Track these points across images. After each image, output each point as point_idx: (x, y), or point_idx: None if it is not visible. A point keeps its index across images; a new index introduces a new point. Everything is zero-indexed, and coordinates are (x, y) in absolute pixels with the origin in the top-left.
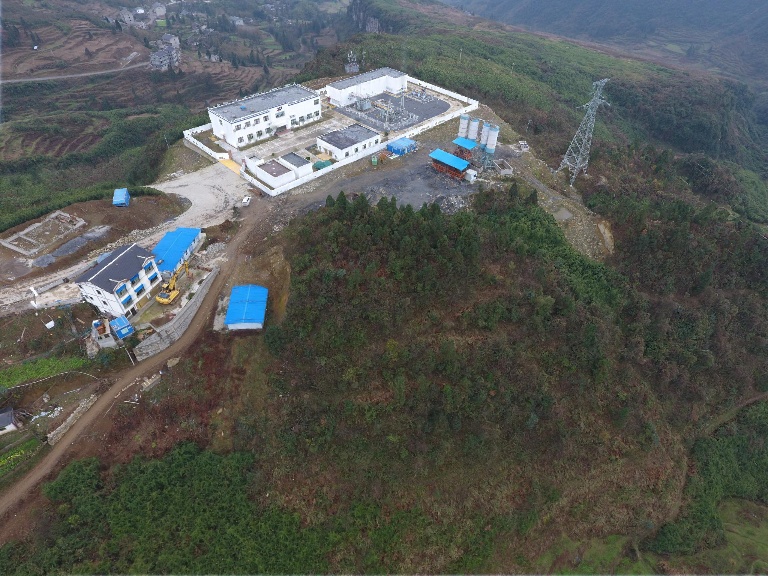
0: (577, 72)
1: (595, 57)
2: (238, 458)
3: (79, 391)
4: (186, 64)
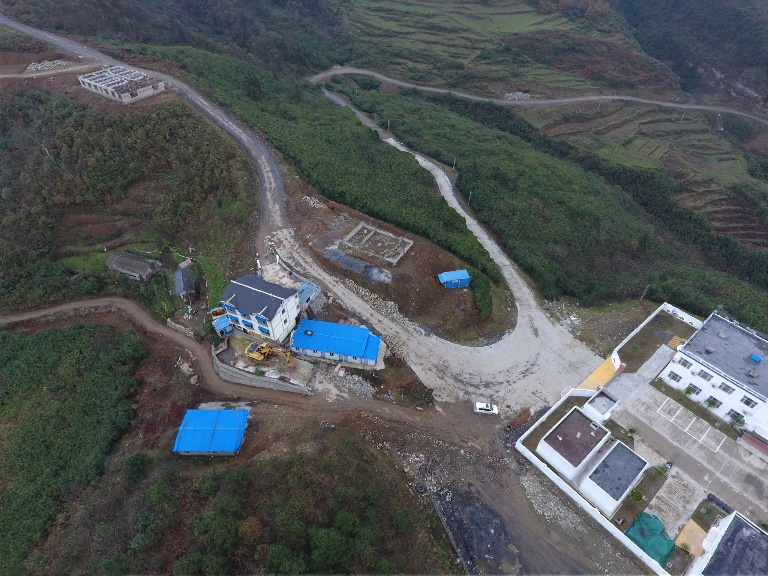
0: None
1: None
2: None
3: None
4: None
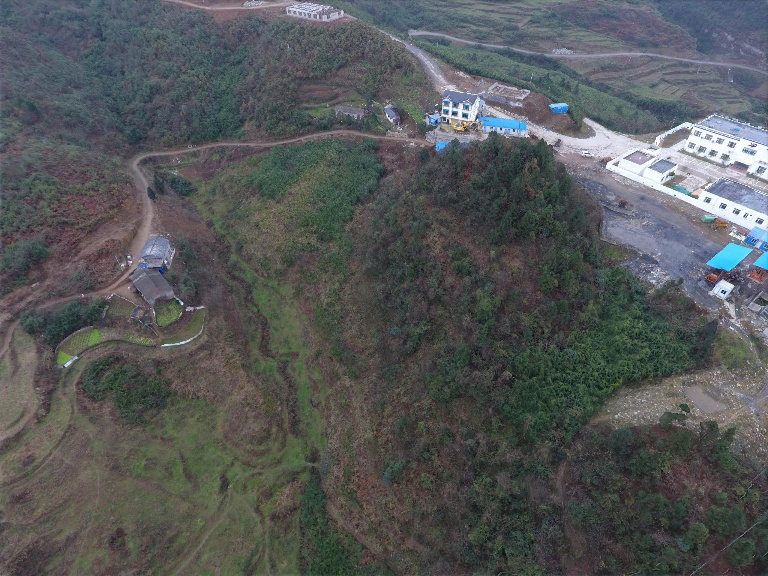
0: None
1: None
2: (374, 184)
3: None
4: None
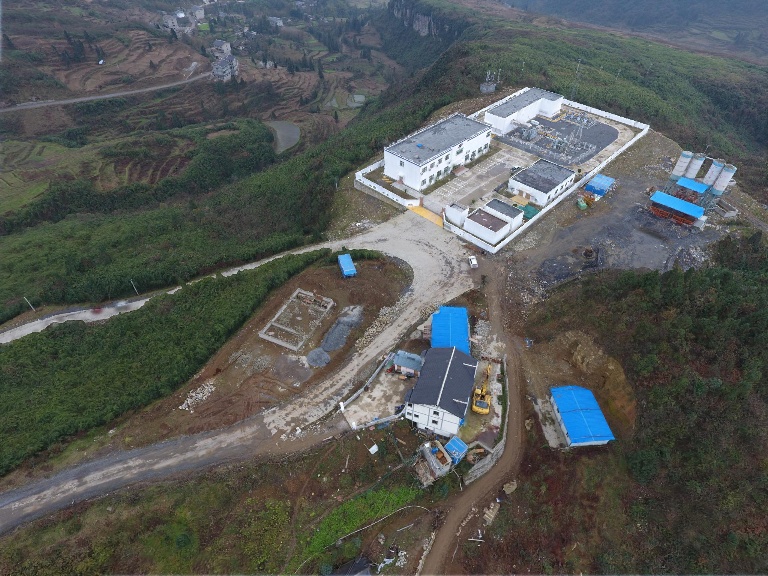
0: (673, 74)
1: (682, 55)
2: None
3: (413, 527)
4: (245, 72)
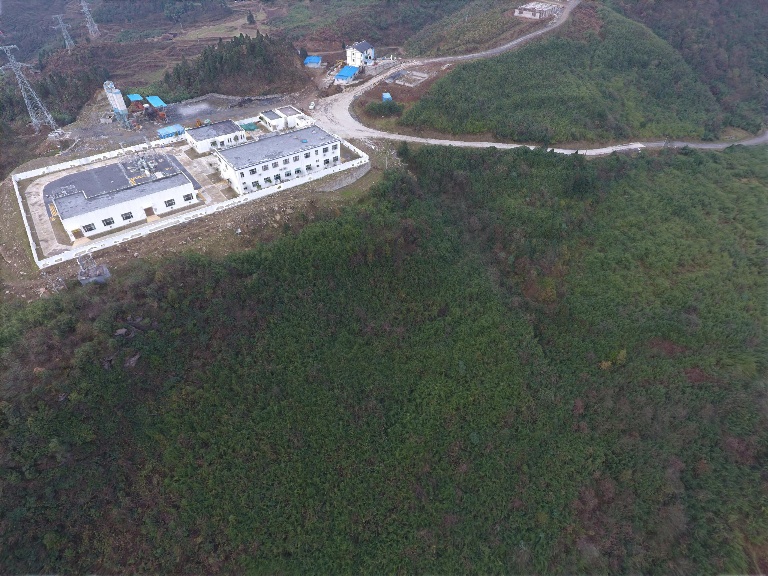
0: None
1: None
2: None
3: None
4: None
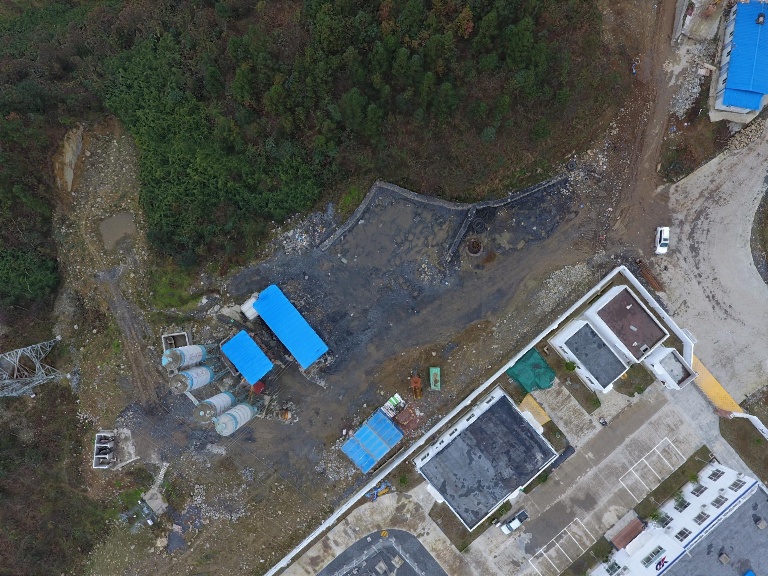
0: None
1: None
2: None
3: None
4: None
